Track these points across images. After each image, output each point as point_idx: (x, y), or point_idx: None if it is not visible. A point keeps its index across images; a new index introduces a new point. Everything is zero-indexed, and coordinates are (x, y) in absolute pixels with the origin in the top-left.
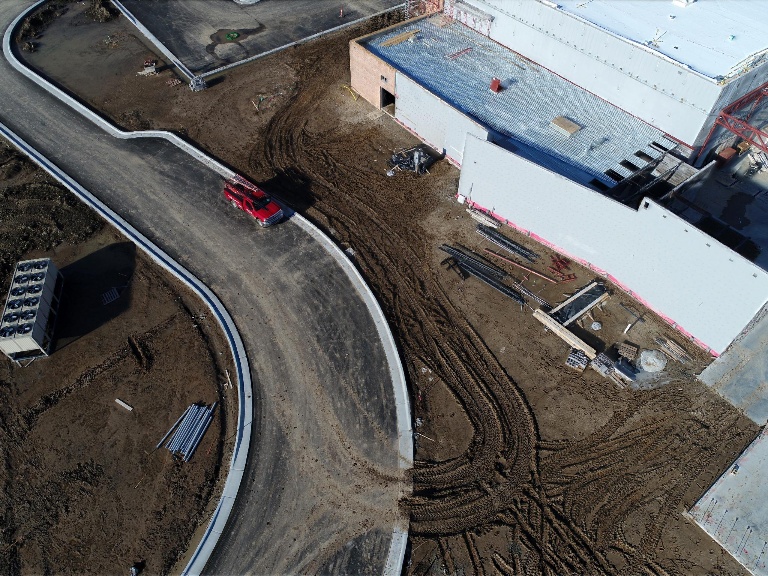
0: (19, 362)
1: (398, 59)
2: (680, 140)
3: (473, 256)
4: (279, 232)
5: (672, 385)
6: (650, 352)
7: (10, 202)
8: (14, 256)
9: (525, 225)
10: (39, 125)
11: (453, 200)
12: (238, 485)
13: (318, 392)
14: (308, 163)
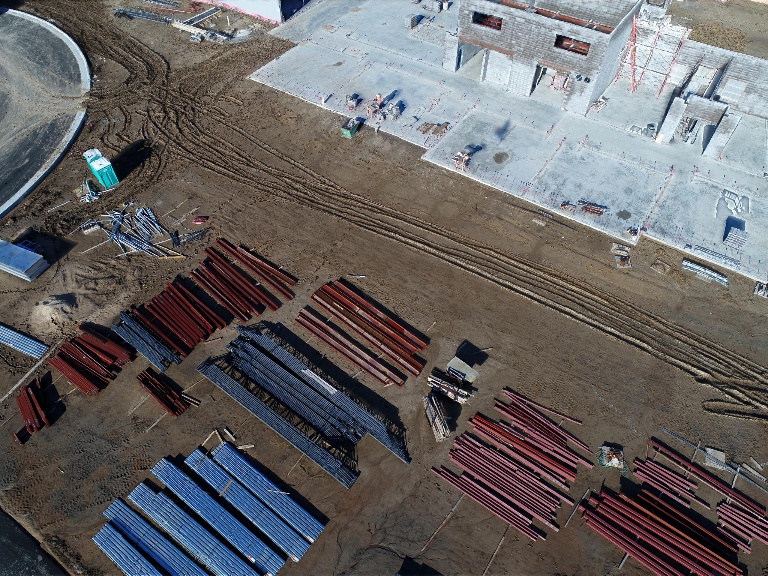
0: None
1: None
2: None
3: (137, 9)
4: None
5: (252, 39)
6: (242, 29)
7: None
8: None
9: None
10: None
11: None
12: None
13: (28, 76)
14: None
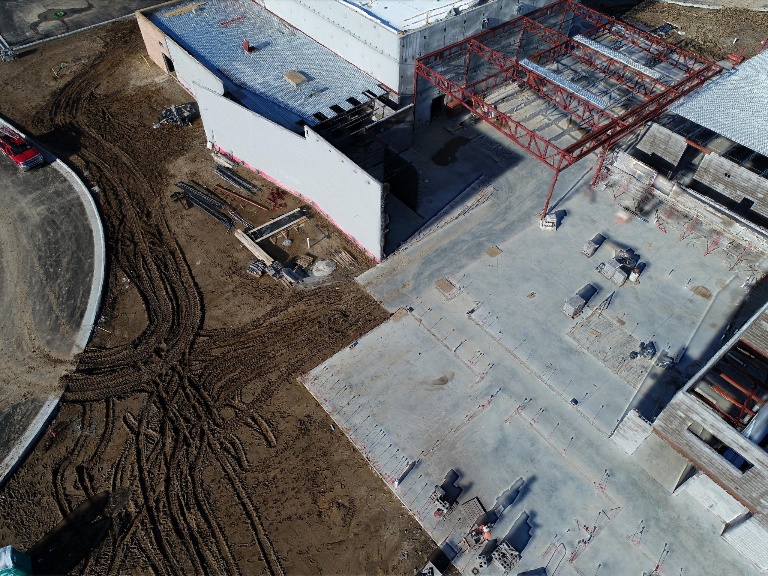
0: None
1: (175, 27)
2: (390, 88)
3: (202, 190)
4: (37, 175)
5: (332, 285)
6: (324, 261)
7: None
8: None
9: (254, 164)
10: None
11: (204, 147)
12: None
13: (23, 298)
14: (86, 119)
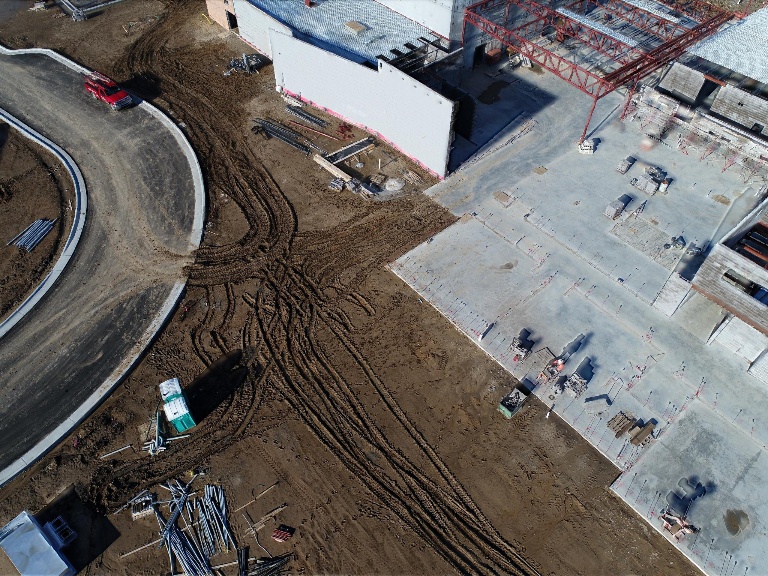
0: None
1: None
2: (441, 35)
3: (278, 125)
4: (128, 114)
5: (404, 197)
6: (394, 179)
7: None
8: None
9: (322, 103)
10: None
11: (273, 90)
12: (65, 263)
13: (137, 210)
14: (162, 69)
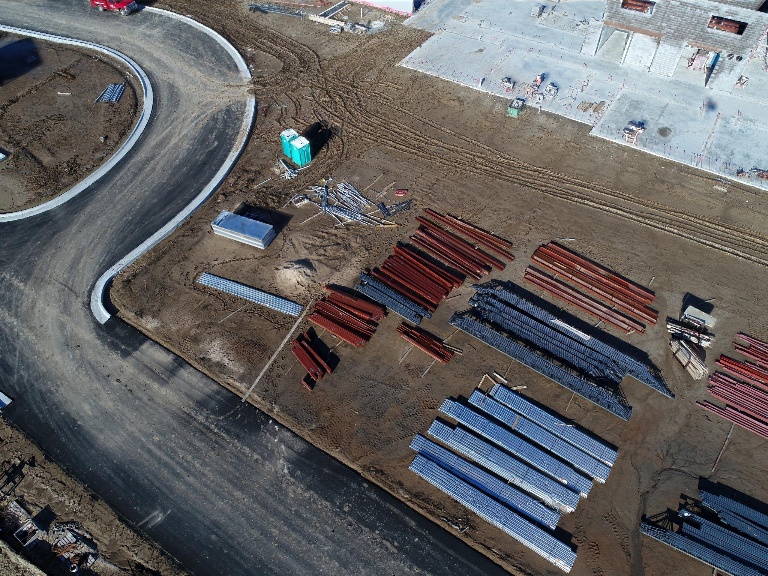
0: None
1: None
2: None
3: (268, 4)
4: (137, 16)
5: (389, 29)
6: None
7: None
8: None
9: None
10: None
11: None
12: (152, 104)
13: (188, 67)
14: None
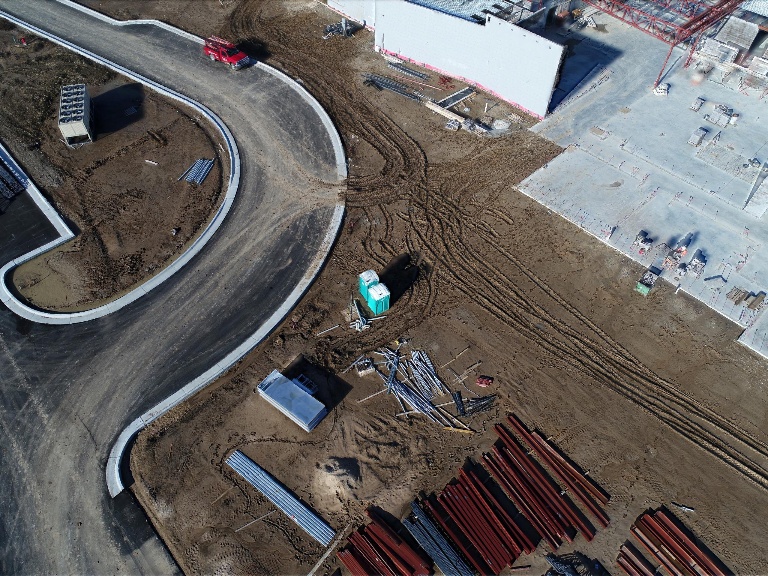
0: (73, 146)
1: None
2: None
3: (386, 79)
4: (247, 73)
5: (513, 134)
6: (500, 120)
7: (41, 65)
8: (53, 93)
9: (421, 59)
10: (51, 20)
11: (372, 50)
12: (235, 193)
13: (283, 150)
14: (265, 35)
